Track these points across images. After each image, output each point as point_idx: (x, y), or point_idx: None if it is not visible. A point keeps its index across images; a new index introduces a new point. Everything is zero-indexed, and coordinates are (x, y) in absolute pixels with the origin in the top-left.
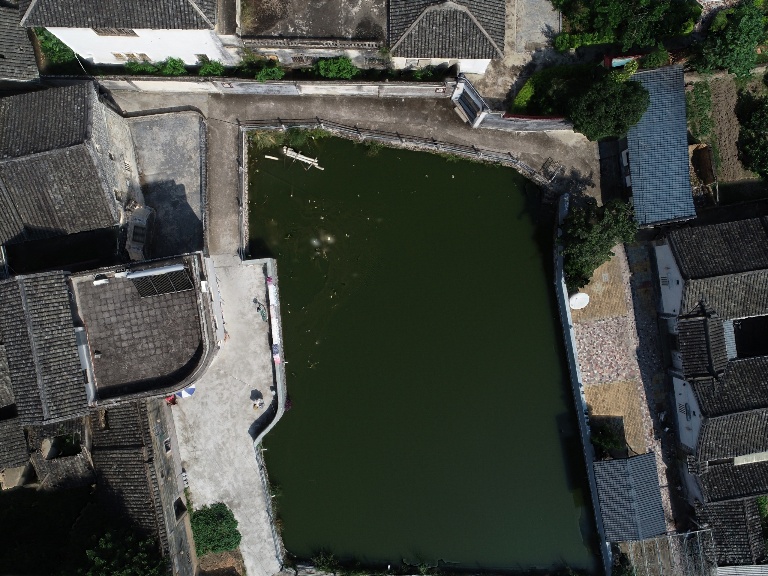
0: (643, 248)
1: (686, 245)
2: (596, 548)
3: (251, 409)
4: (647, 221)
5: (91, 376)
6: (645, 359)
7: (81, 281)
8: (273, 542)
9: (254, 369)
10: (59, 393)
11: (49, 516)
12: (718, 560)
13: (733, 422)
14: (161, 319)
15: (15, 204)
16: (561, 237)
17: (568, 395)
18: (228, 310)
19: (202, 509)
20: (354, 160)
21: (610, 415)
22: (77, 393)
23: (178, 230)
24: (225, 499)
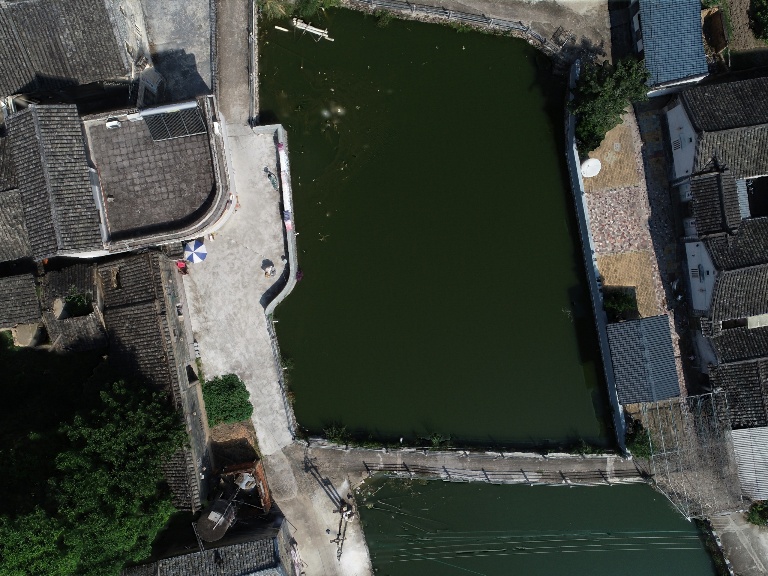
0: (654, 117)
1: (699, 102)
2: (609, 421)
3: (262, 279)
4: (659, 81)
5: (104, 219)
6: (657, 229)
7: (93, 125)
8: (285, 413)
9: (265, 239)
10: (73, 225)
11: (61, 385)
12: (732, 424)
13: (747, 277)
14: (174, 163)
15: (27, 50)
16: (573, 101)
17: (580, 268)
18: (239, 179)
19: (214, 380)
20: (364, 31)
21: (622, 285)
22: (91, 227)
23: None
24: (237, 370)
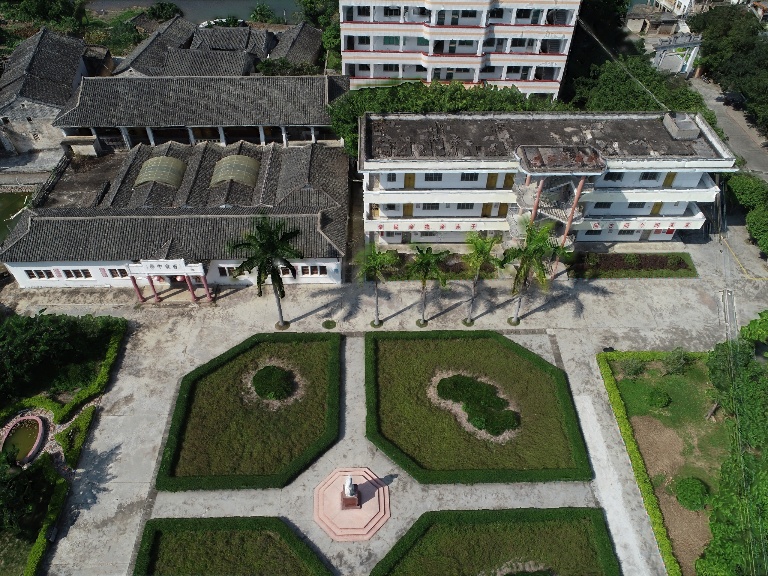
0: None
1: None
2: None
3: None
4: None
5: None
6: None
7: None
8: None
9: None
10: None
11: None
12: None
13: None
14: None
15: None
16: None
17: None
18: None
19: None
20: (3, 235)
21: None
22: None
23: (0, 164)
24: None
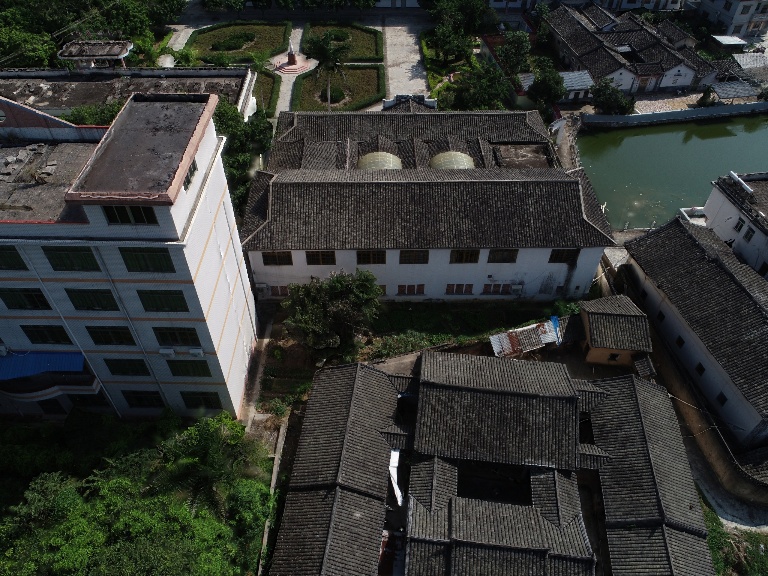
0: None
1: None
2: None
3: None
4: (594, 84)
5: None
6: (653, 99)
7: (766, 227)
8: None
9: None
10: None
11: None
12: None
13: None
14: (765, 195)
15: None
16: None
17: None
18: None
19: None
20: None
21: None
22: None
23: None
24: None
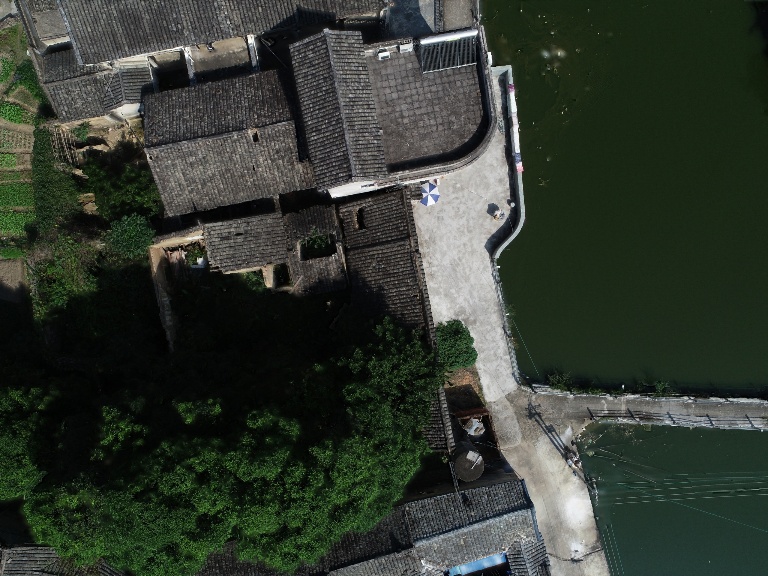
0: None
1: None
2: None
3: (488, 223)
4: None
5: None
6: None
7: None
8: (509, 359)
9: (491, 182)
10: (362, 153)
11: (288, 331)
12: None
13: None
14: (443, 95)
15: None
16: None
17: None
18: None
19: (438, 326)
20: None
21: None
22: (377, 156)
23: None
24: (461, 316)
